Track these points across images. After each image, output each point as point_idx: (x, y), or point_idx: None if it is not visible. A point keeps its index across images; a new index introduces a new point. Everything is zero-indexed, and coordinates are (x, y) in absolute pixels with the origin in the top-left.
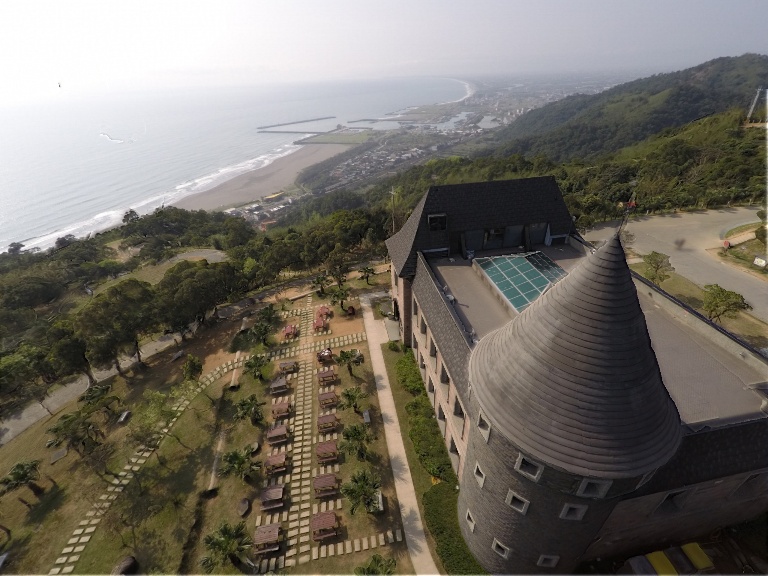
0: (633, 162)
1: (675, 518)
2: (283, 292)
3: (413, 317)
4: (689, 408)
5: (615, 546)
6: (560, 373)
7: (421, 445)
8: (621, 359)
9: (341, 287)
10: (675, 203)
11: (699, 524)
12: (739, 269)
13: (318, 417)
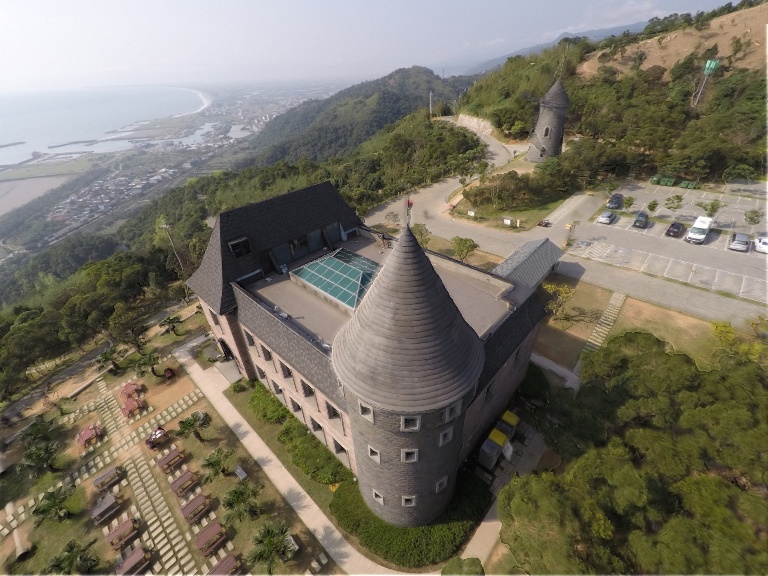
0: (374, 155)
1: (494, 402)
2: (52, 393)
3: (250, 349)
4: (477, 327)
5: (471, 444)
6: (407, 341)
7: (308, 465)
8: (439, 313)
9: (142, 352)
10: (413, 183)
11: (504, 398)
12: (463, 221)
13: (181, 509)
